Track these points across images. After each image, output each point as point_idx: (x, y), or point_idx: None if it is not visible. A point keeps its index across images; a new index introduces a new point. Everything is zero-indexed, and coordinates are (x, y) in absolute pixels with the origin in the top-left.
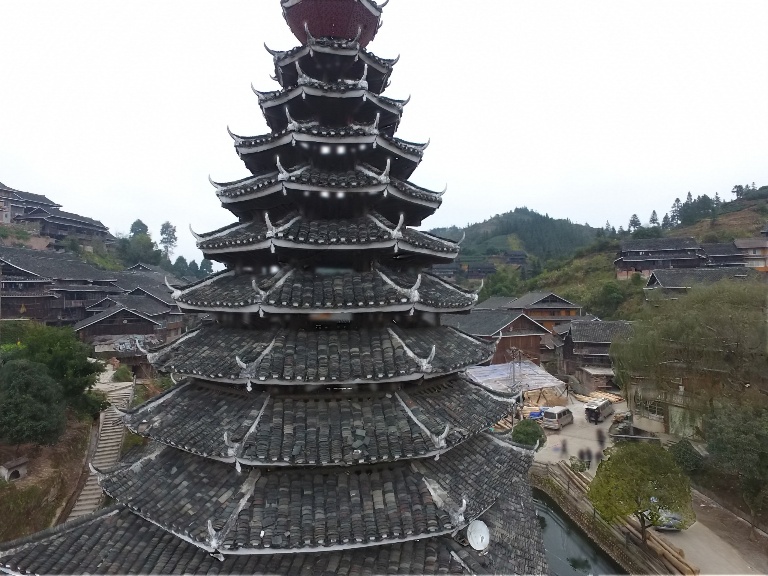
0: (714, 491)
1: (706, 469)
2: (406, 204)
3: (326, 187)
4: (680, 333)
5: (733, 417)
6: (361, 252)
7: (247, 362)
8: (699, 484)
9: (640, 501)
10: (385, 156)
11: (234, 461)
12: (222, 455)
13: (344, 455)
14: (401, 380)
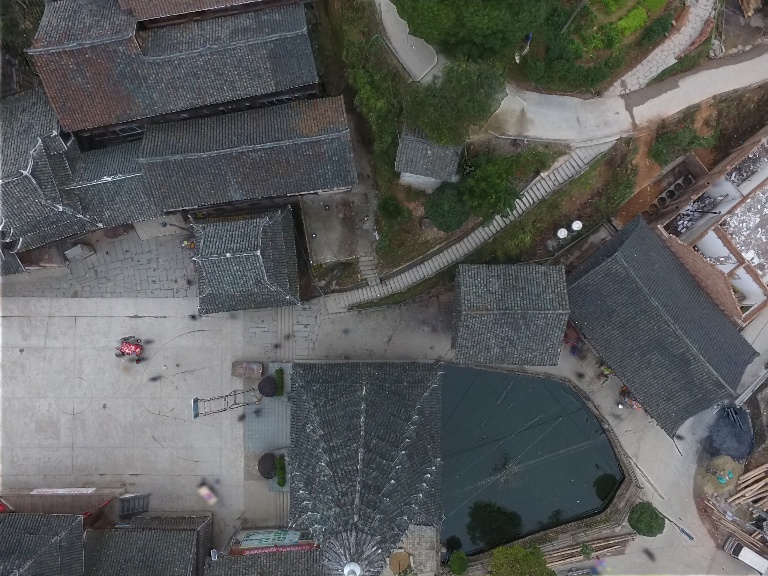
0: None
1: None
2: None
3: None
4: None
5: None
6: None
7: None
8: None
9: None
10: None
11: None
12: None
13: None
14: None
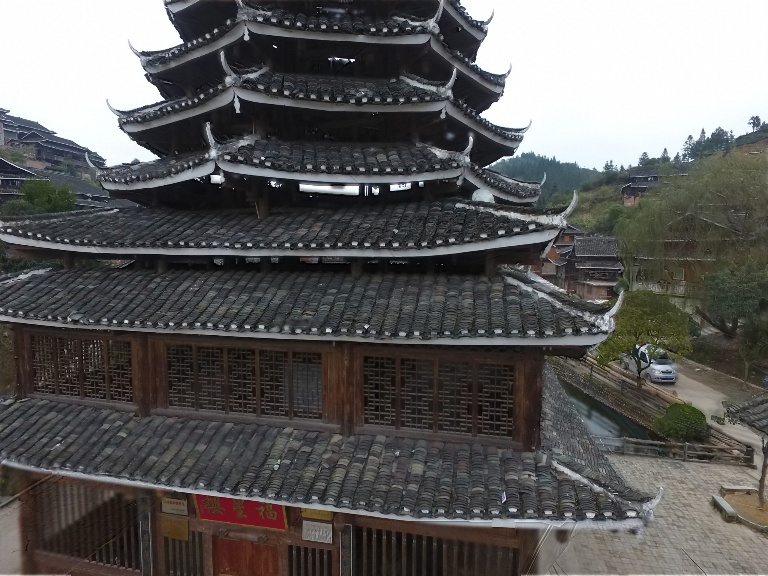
0: (709, 364)
1: (703, 347)
2: None
3: None
4: (688, 203)
5: (736, 273)
6: None
7: (243, 2)
8: (695, 360)
9: (638, 336)
10: None
11: (232, 97)
12: (220, 88)
13: (347, 97)
14: (406, 43)
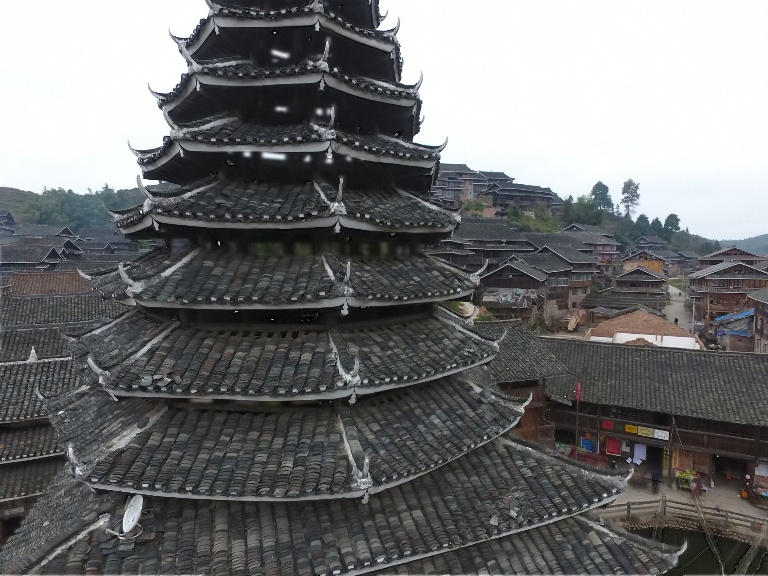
0: None
1: None
2: (256, 91)
3: (174, 101)
4: None
5: None
6: (181, 164)
7: (93, 275)
8: None
9: None
10: (258, 37)
11: None
12: None
13: None
14: None
